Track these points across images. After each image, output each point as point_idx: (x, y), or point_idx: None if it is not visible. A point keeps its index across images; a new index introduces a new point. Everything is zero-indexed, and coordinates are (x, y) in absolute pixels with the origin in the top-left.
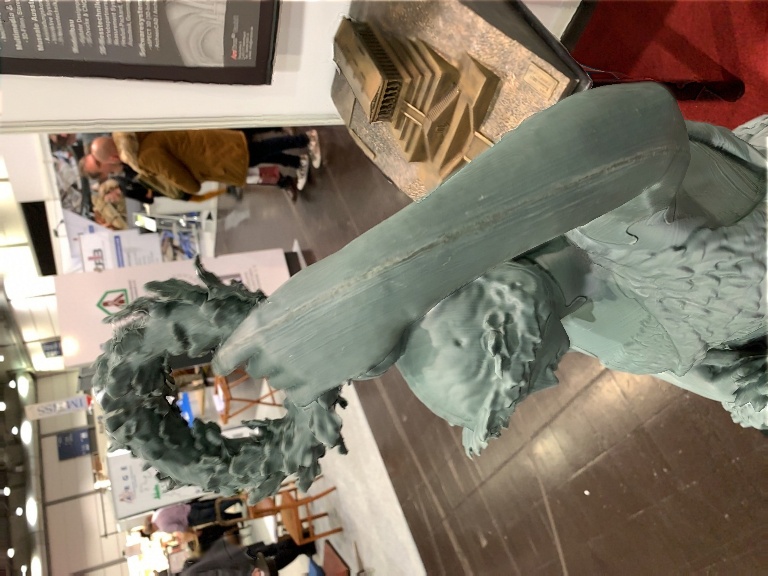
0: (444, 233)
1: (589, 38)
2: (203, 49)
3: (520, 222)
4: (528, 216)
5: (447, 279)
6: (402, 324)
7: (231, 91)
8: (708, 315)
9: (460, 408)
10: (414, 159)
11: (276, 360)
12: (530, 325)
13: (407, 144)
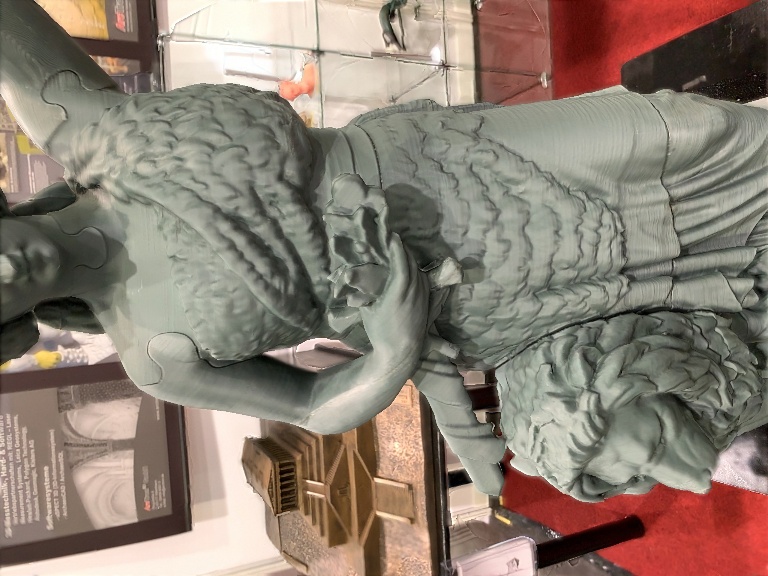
0: None
1: None
2: (113, 507)
3: None
4: None
5: None
6: None
7: (150, 548)
8: (183, 163)
9: None
10: (334, 542)
11: None
12: None
13: (320, 526)
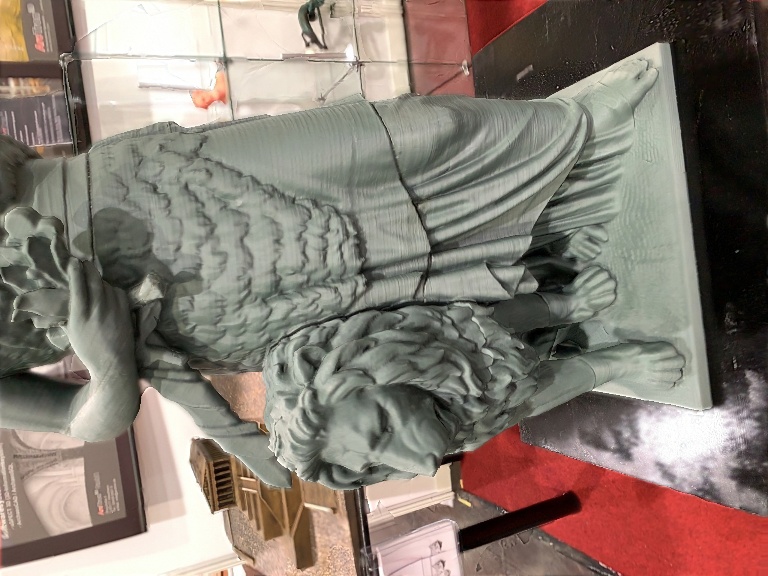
0: None
1: None
2: (67, 513)
3: None
4: None
5: None
6: None
7: (106, 551)
8: None
9: None
10: (270, 535)
11: None
12: None
13: (256, 521)
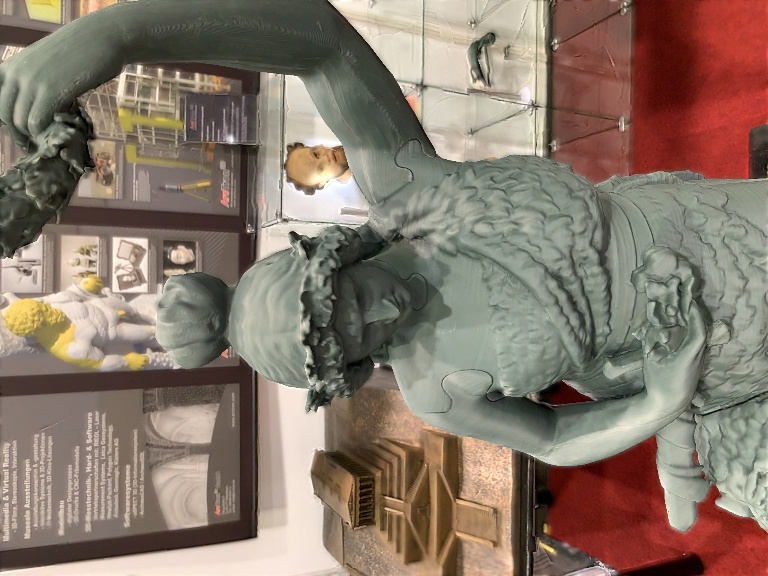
0: None
1: None
2: (187, 509)
3: None
4: None
5: (148, 12)
6: (115, 36)
7: (217, 552)
8: (519, 227)
9: (280, 313)
10: (409, 558)
11: (14, 69)
12: (333, 232)
13: (396, 542)
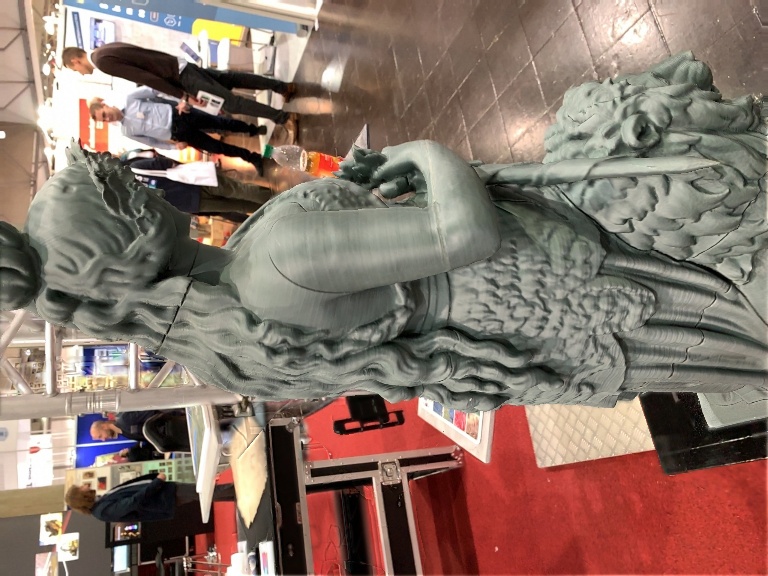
0: None
1: None
2: None
3: None
4: None
5: None
6: None
7: None
8: None
9: None
10: None
11: None
12: None
13: None
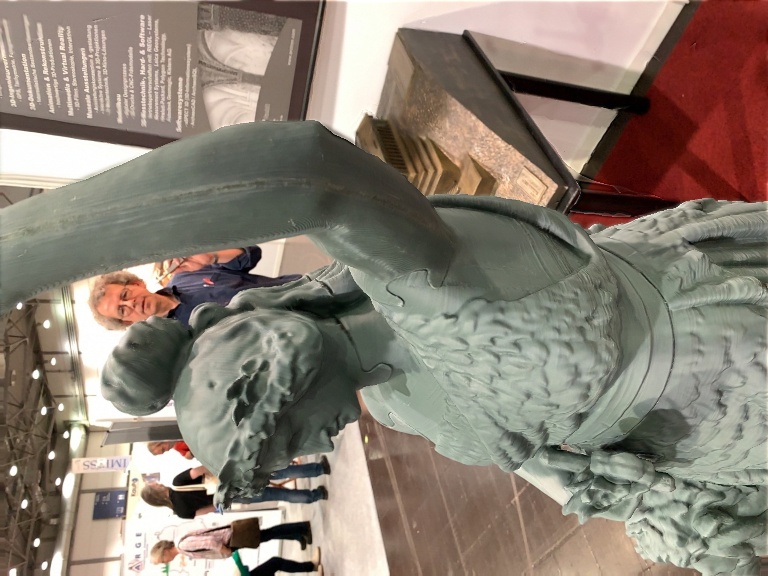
0: (26, 226)
1: (617, 157)
2: None
3: (109, 226)
4: (118, 222)
5: (24, 272)
6: None
7: None
8: (496, 396)
9: (207, 455)
10: None
11: None
12: (282, 375)
13: None
